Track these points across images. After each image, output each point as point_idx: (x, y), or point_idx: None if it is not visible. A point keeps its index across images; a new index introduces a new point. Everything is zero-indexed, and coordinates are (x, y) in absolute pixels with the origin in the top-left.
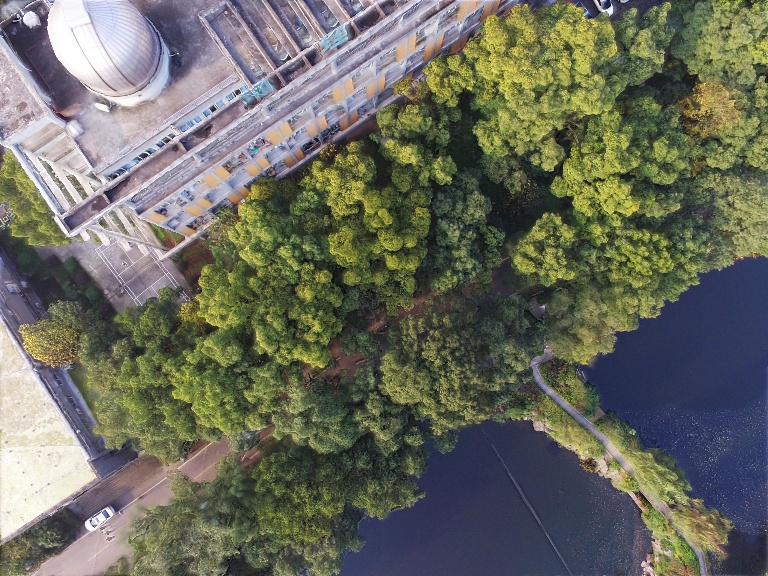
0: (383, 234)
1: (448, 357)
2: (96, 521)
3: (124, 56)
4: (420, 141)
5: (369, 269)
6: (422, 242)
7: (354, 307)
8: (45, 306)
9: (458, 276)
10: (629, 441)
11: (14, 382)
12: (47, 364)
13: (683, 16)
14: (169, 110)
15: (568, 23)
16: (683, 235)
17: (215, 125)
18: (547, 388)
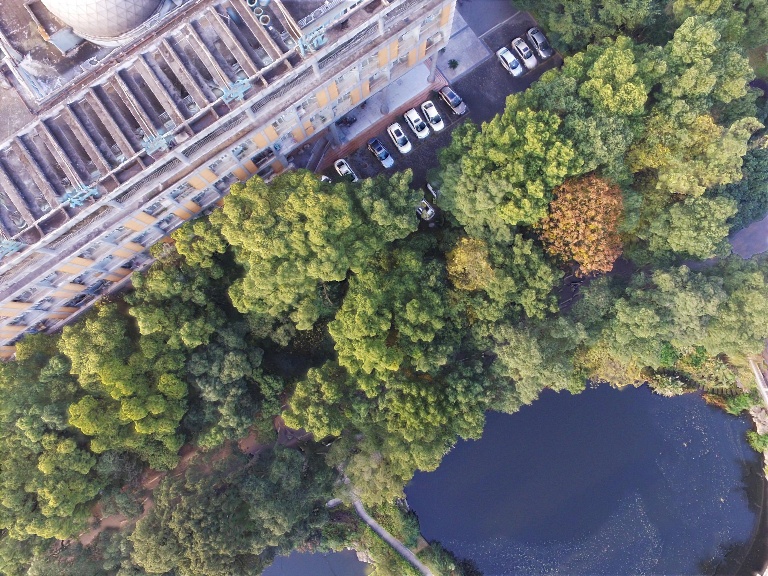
0: (124, 404)
1: (192, 529)
2: None
3: None
4: (179, 300)
5: (117, 435)
6: (179, 403)
7: (111, 469)
8: None
9: (222, 434)
10: (451, 575)
11: None
12: None
13: (439, 175)
14: None
15: (298, 197)
16: (456, 387)
17: None
18: (369, 518)
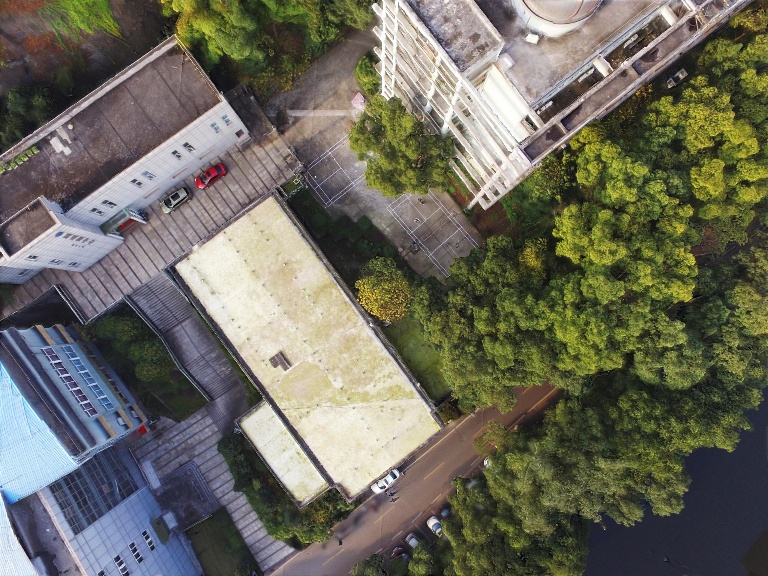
0: (747, 164)
1: None
2: (384, 482)
3: None
4: None
5: (724, 202)
6: None
7: (697, 243)
8: None
9: None
10: None
11: (351, 339)
12: (380, 319)
13: None
14: (595, 39)
15: None
16: None
17: (661, 49)
18: None
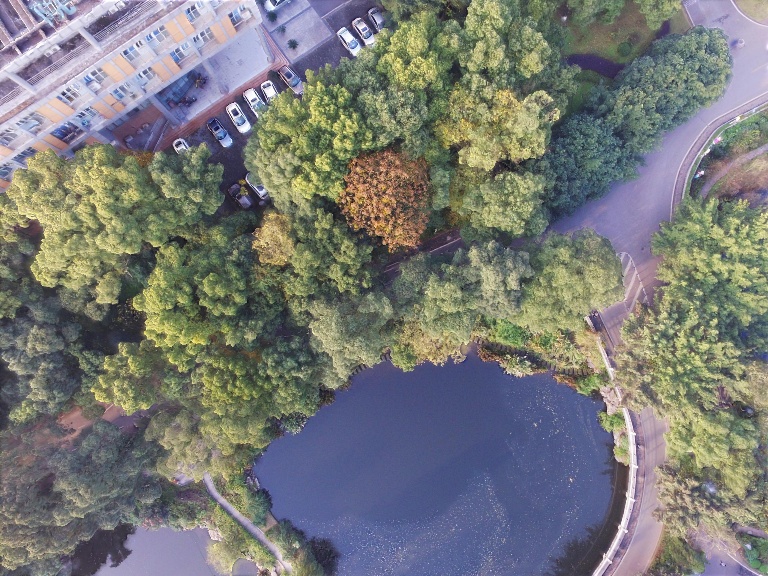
0: None
1: None
2: None
3: None
4: None
5: None
6: None
7: None
8: None
9: (32, 407)
10: (298, 553)
11: None
12: None
13: (243, 150)
14: None
15: (84, 170)
16: (267, 362)
17: None
18: (219, 496)
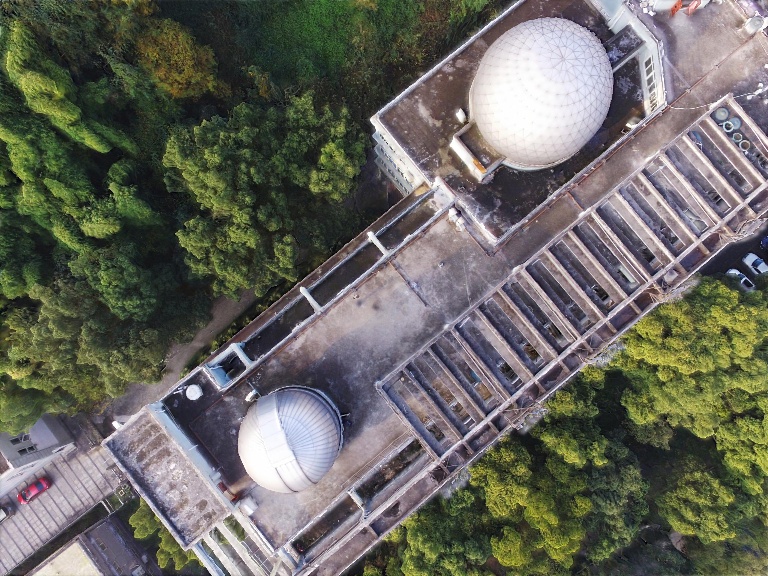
0: (548, 534)
1: None
2: None
3: (322, 472)
4: None
5: (531, 563)
6: (578, 520)
7: None
8: (165, 575)
9: (614, 545)
10: None
11: None
12: None
13: None
14: (344, 474)
15: (725, 311)
16: None
17: (403, 502)
18: None
